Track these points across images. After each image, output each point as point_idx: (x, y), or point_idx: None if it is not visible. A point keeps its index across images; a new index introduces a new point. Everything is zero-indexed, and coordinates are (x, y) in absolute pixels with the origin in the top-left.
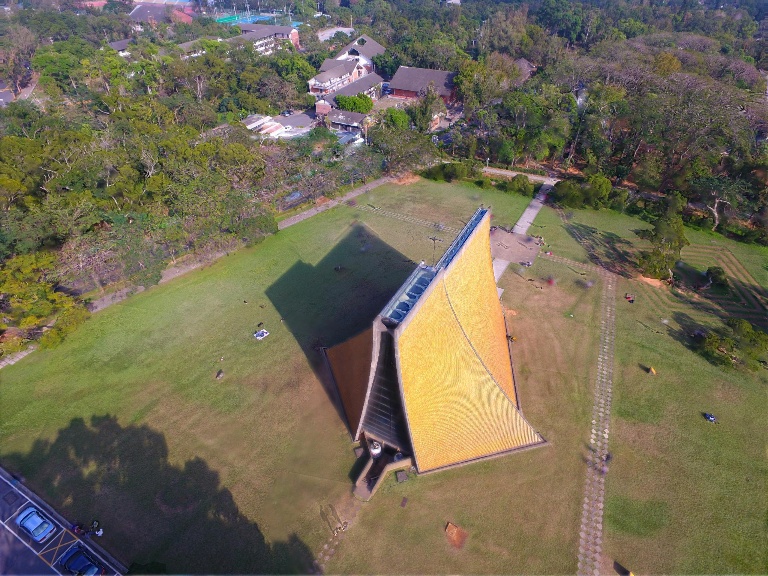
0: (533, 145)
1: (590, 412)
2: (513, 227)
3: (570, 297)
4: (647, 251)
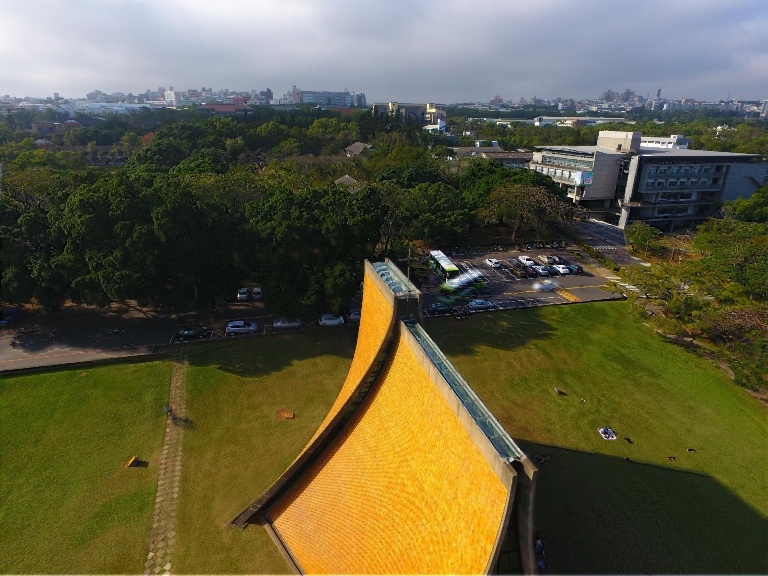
0: None
1: None
2: None
3: None
4: None
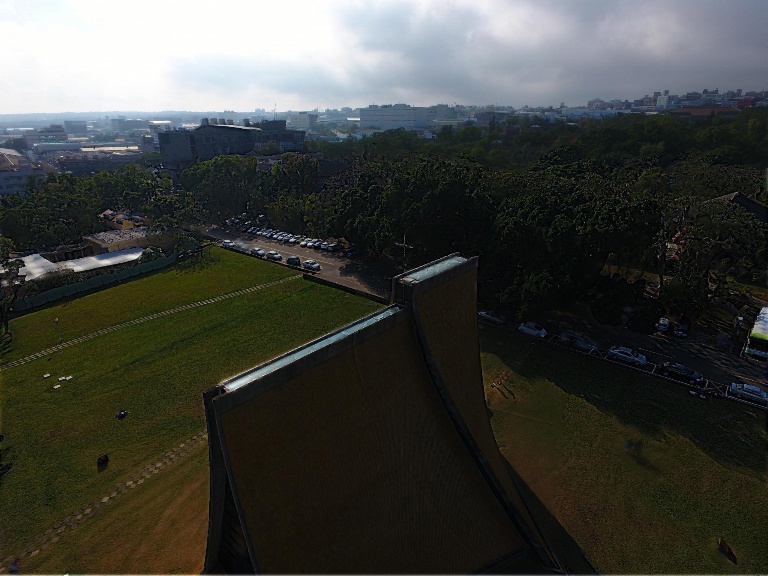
0: None
1: None
2: None
3: None
4: None
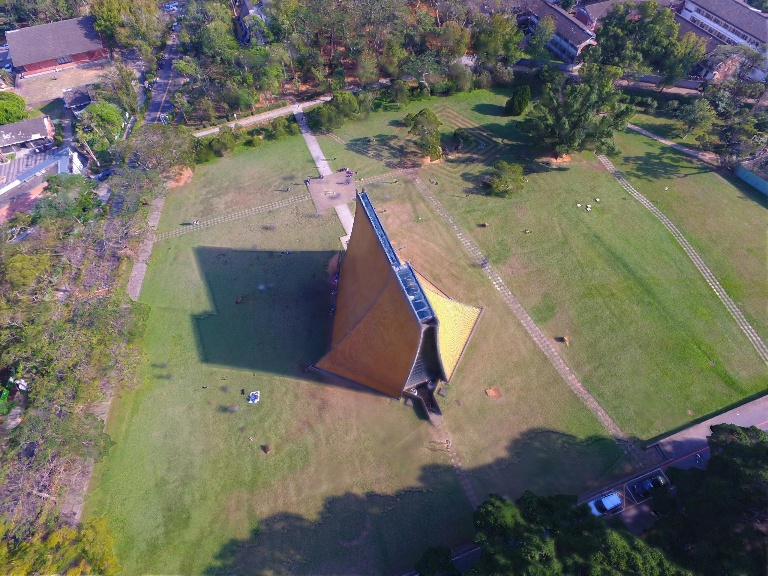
0: (265, 84)
1: (484, 274)
2: (318, 172)
3: (406, 205)
4: (419, 141)
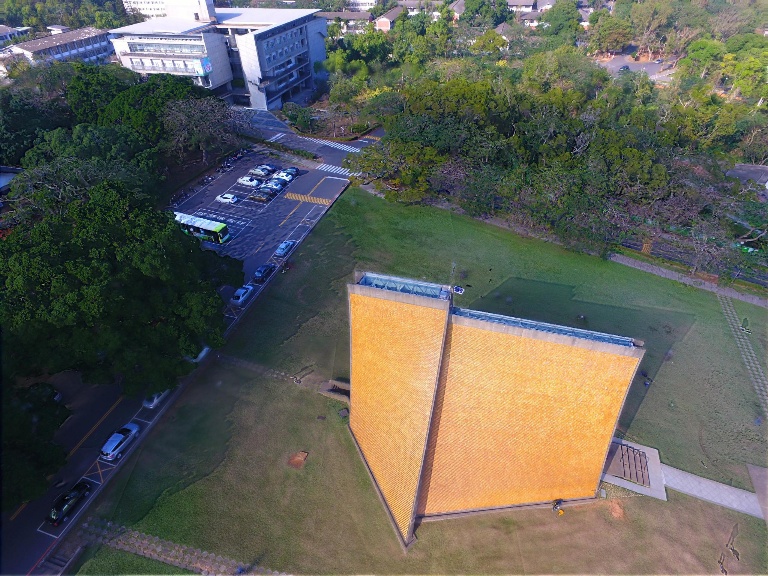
0: None
1: None
2: None
3: None
4: None
